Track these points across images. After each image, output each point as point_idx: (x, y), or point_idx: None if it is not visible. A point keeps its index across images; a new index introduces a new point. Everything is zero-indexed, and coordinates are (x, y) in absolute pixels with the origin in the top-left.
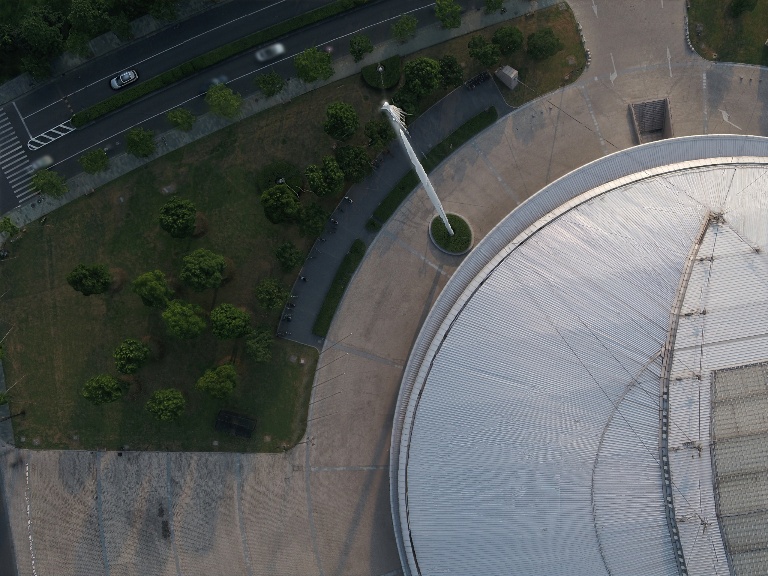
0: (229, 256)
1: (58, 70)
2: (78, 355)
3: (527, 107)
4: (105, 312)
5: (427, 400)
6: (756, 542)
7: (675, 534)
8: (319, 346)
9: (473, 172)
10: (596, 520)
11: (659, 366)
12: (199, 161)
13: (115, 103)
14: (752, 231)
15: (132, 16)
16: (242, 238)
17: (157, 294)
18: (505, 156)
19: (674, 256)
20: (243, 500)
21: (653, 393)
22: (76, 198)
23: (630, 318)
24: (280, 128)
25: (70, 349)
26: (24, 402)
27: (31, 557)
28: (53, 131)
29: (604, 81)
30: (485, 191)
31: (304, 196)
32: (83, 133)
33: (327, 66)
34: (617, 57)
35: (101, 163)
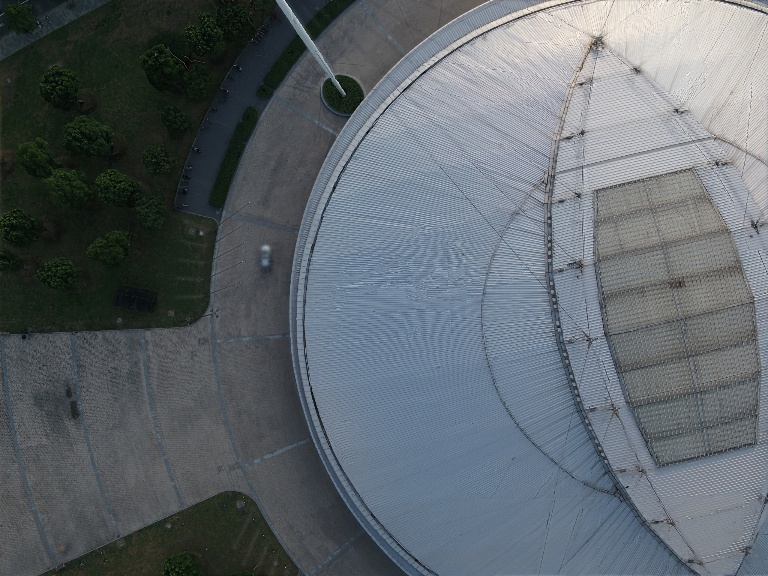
0: (120, 131)
1: None
2: None
3: None
4: None
5: (319, 252)
6: (646, 358)
7: (566, 358)
8: (217, 217)
9: (362, 32)
10: (487, 352)
11: (542, 192)
12: (84, 37)
13: None
14: (636, 57)
15: None
16: (132, 112)
17: (38, 160)
18: (394, 14)
19: (555, 85)
20: (150, 376)
21: (537, 219)
22: None
23: (512, 148)
24: None
25: None
26: None
27: None
28: None
29: None
30: (376, 51)
31: (192, 66)
32: None
33: None
34: None
35: None
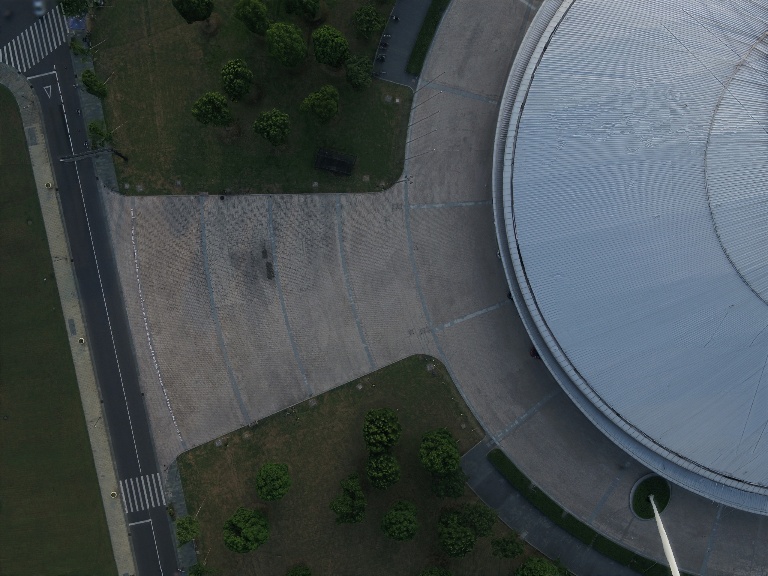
0: None
1: None
2: (177, 100)
3: None
4: (202, 56)
5: (530, 110)
6: None
7: None
8: (413, 85)
9: None
10: (710, 200)
11: (767, 45)
12: None
13: None
14: None
15: None
16: None
17: (261, 11)
18: None
19: None
20: (345, 240)
21: (763, 71)
22: None
23: (735, 4)
24: None
25: (169, 95)
26: (126, 149)
27: (140, 300)
28: None
29: None
30: None
31: None
32: None
33: None
34: None
35: None
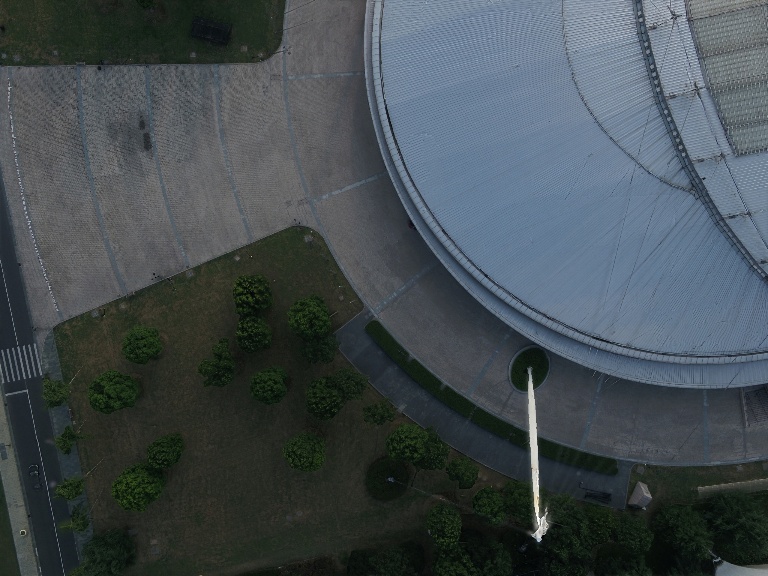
0: None
1: None
2: None
3: None
4: None
5: None
6: (728, 44)
7: (647, 49)
8: None
9: None
10: (567, 46)
11: None
12: None
13: None
14: None
15: None
16: None
17: None
18: None
19: None
20: (222, 110)
21: None
22: None
23: None
24: None
25: None
26: (3, 19)
27: (16, 170)
28: None
29: None
30: None
31: None
32: None
33: None
34: None
35: None
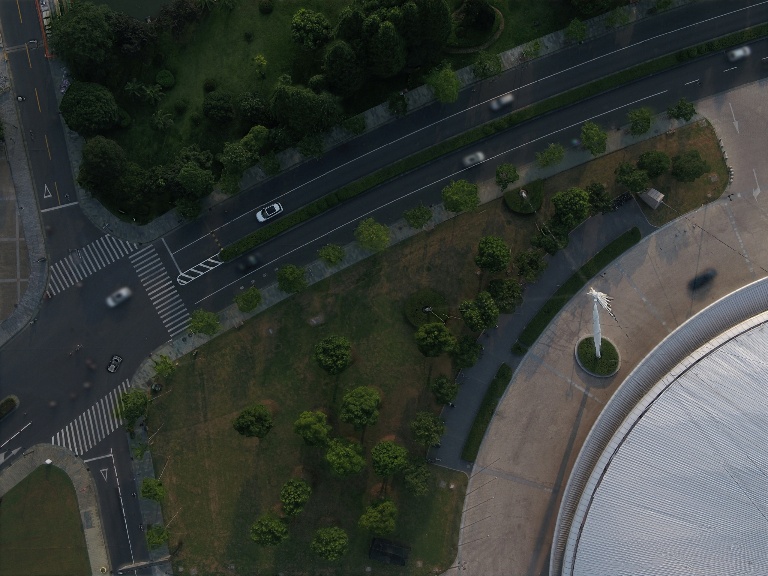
0: (378, 384)
1: (205, 205)
2: (233, 486)
3: (670, 226)
4: (258, 443)
5: (589, 535)
6: None
7: None
8: (468, 471)
9: (617, 293)
10: None
11: None
12: (345, 291)
13: (262, 236)
14: None
15: (277, 150)
16: (390, 366)
17: (321, 437)
18: (649, 276)
19: None
20: None
21: None
22: (226, 331)
23: None
24: (424, 255)
25: (225, 480)
26: (181, 533)
27: None
28: (202, 265)
29: (747, 197)
30: (630, 312)
31: (450, 323)
32: (231, 266)
33: (476, 199)
34: (760, 173)
35: (256, 302)
